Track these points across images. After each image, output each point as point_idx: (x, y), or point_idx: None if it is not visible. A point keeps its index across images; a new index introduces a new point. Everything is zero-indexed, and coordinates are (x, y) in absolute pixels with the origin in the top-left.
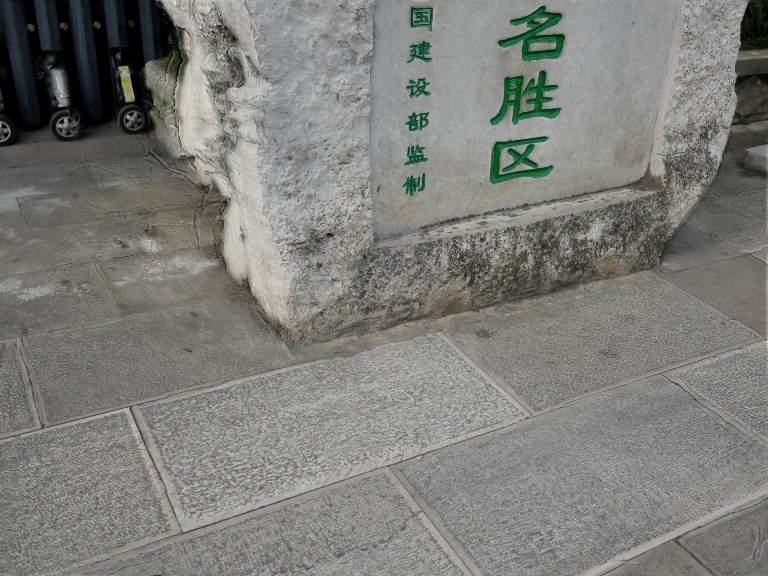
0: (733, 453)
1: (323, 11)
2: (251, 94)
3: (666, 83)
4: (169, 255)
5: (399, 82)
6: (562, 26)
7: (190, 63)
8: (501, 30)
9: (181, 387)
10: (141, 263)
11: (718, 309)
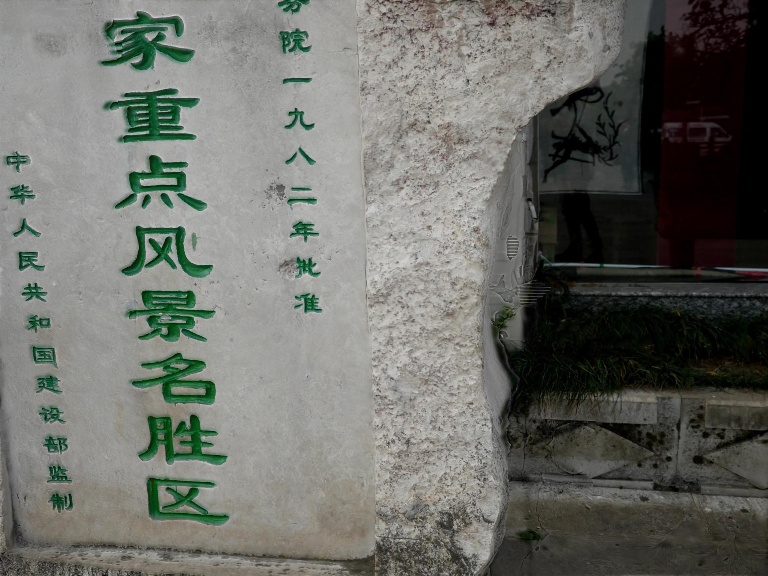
0: None
1: None
2: None
3: None
4: None
5: (30, 408)
6: (208, 374)
7: None
8: (133, 372)
9: None
10: None
11: None
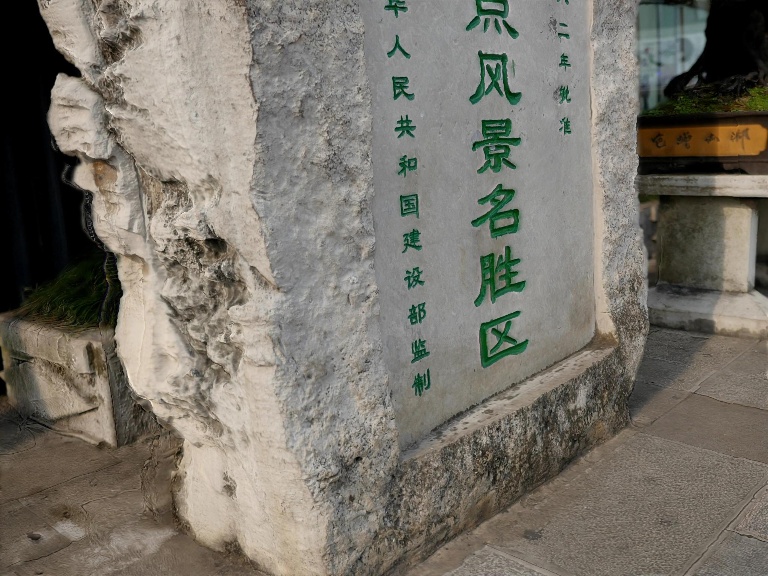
0: None
1: (327, 207)
2: (264, 309)
3: (595, 245)
4: (121, 536)
5: (398, 274)
6: (516, 201)
7: (143, 293)
8: (472, 210)
9: None
10: (78, 556)
11: (715, 450)
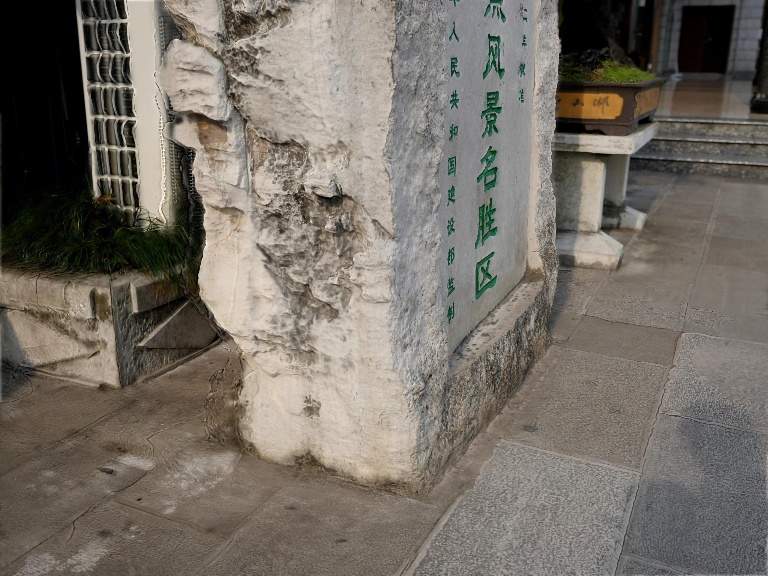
0: (760, 446)
1: (420, 169)
2: (385, 255)
3: (530, 195)
4: (205, 460)
5: (445, 224)
6: (497, 160)
7: (238, 242)
8: (478, 169)
9: (389, 575)
10: (161, 482)
11: (623, 358)
